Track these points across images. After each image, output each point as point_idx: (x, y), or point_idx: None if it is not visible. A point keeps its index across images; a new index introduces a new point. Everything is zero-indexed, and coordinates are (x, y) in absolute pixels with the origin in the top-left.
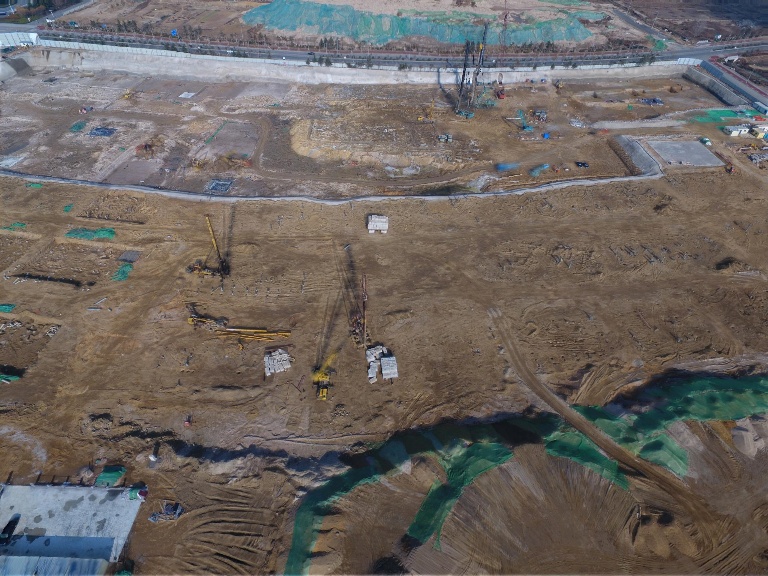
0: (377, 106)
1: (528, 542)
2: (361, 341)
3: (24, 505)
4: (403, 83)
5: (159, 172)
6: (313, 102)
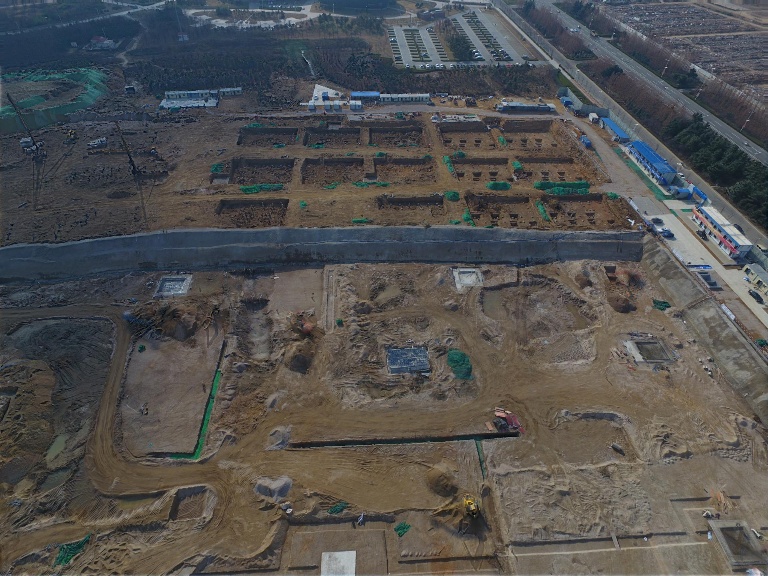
0: None
1: None
2: None
3: None
4: None
5: (265, 298)
6: None
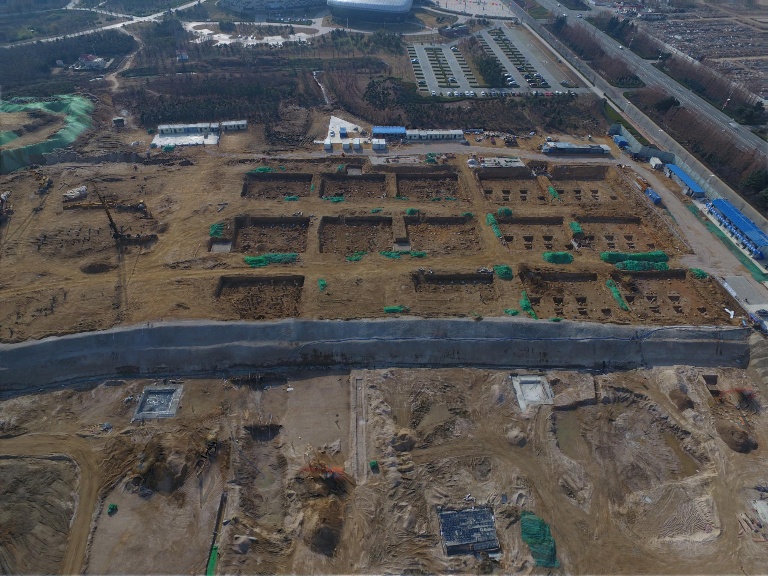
0: None
1: None
2: (5, 203)
3: None
4: None
5: (276, 422)
6: None
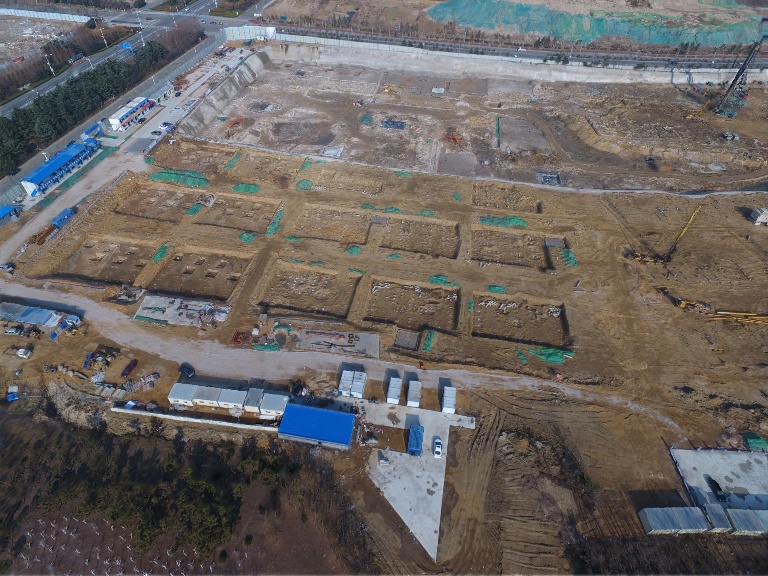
0: (634, 104)
1: None
2: None
3: (704, 467)
4: (637, 82)
5: (479, 164)
6: (567, 99)
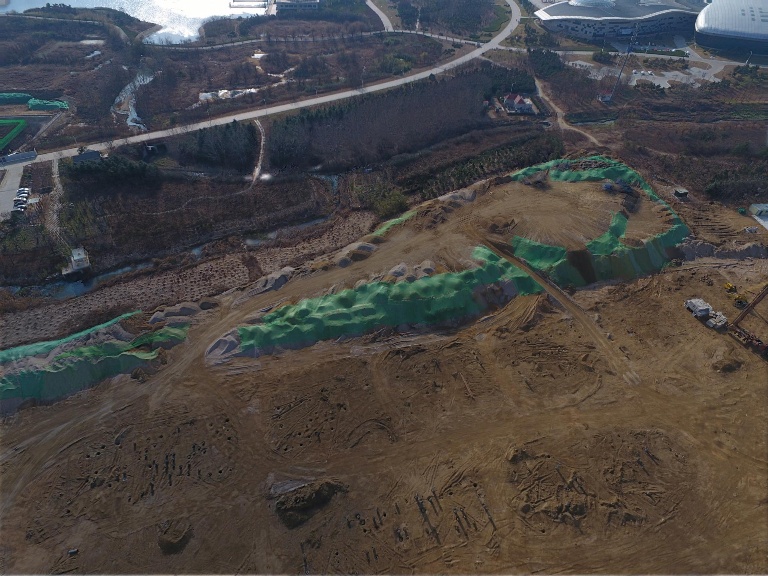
0: None
1: (567, 215)
2: None
3: None
4: None
5: None
6: None
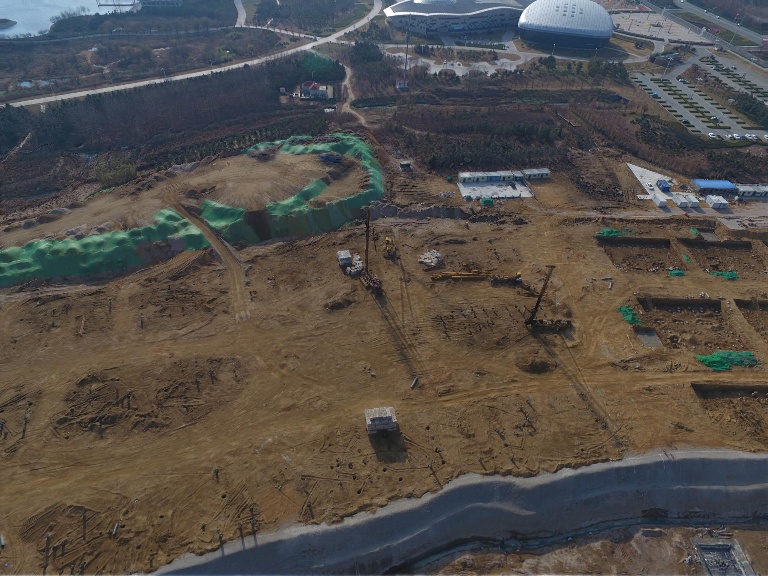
0: None
1: (269, 182)
2: None
3: (517, 192)
4: None
5: None
6: None
